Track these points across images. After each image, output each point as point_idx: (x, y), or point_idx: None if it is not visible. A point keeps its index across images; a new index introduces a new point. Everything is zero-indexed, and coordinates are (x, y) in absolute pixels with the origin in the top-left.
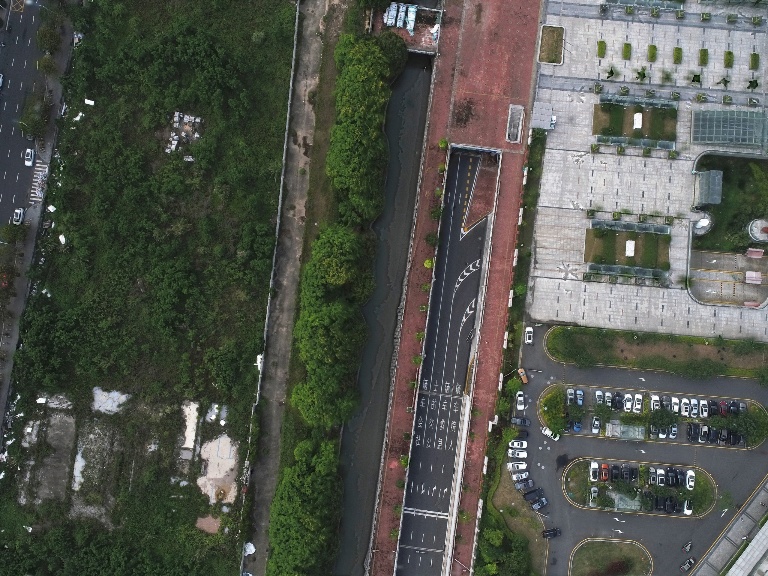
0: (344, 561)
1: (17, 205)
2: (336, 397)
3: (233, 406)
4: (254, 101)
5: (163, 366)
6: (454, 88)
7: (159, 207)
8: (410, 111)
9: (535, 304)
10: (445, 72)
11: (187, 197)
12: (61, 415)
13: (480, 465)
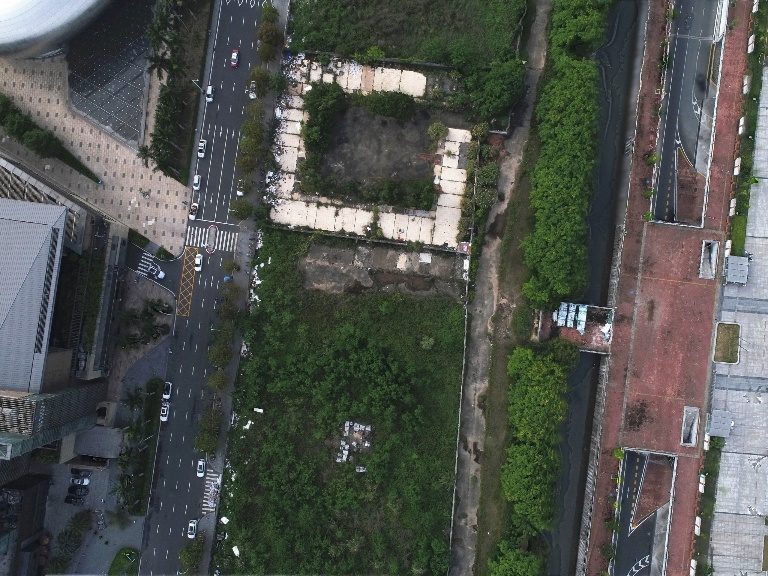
0: None
1: (190, 516)
2: None
3: None
4: (425, 409)
5: None
6: (626, 389)
7: (332, 520)
8: (577, 404)
9: None
10: (617, 373)
11: (360, 509)
12: None
13: None
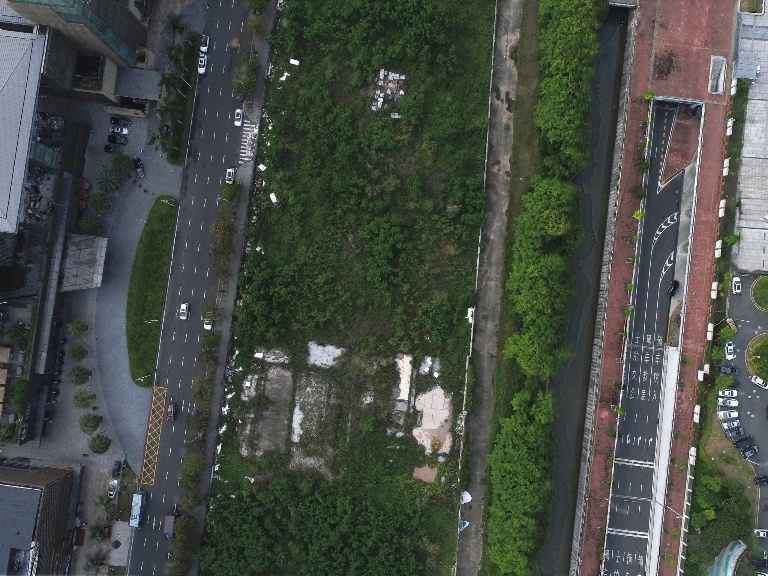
0: (558, 509)
1: (228, 165)
2: (553, 347)
3: (446, 358)
4: (458, 57)
5: (376, 320)
6: (655, 40)
7: (368, 164)
8: (605, 65)
9: (741, 254)
10: (645, 24)
11: (395, 154)
12: (278, 369)
13: (690, 414)
